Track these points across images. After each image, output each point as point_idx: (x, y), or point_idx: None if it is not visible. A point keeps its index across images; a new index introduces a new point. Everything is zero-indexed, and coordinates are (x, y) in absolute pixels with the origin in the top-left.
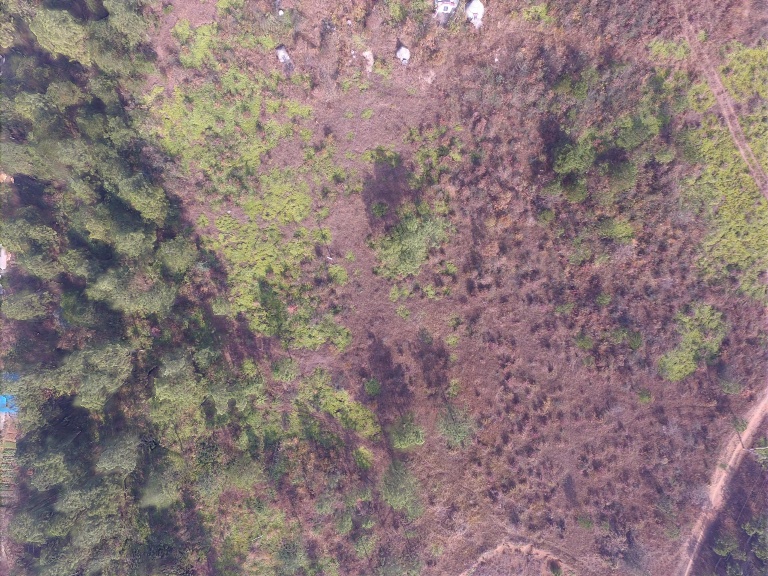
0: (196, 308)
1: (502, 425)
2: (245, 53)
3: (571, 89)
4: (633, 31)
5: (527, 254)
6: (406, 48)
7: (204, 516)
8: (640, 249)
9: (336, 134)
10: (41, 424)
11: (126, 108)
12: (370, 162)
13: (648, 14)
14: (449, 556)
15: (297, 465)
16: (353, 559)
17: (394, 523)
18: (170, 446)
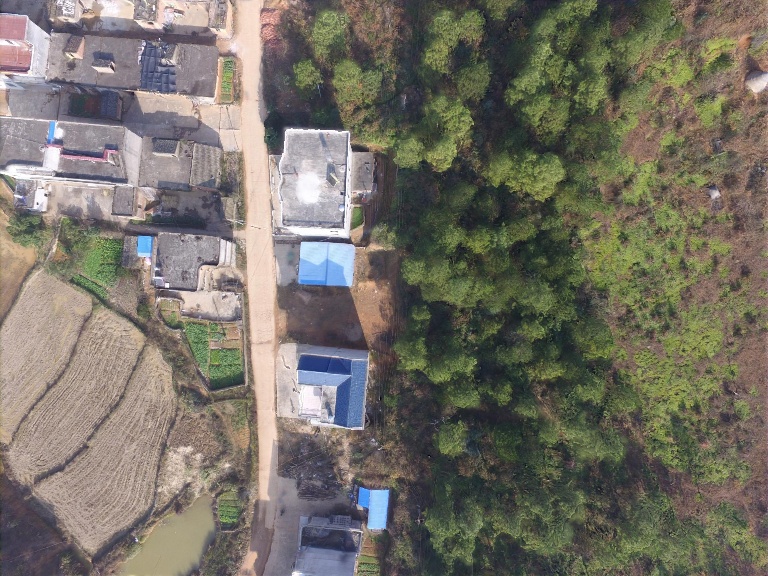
0: None
1: None
2: (679, 191)
3: None
4: None
5: None
6: None
7: None
8: None
9: (753, 273)
10: None
11: (573, 245)
12: None
13: None
14: None
15: None
16: None
17: None
18: None
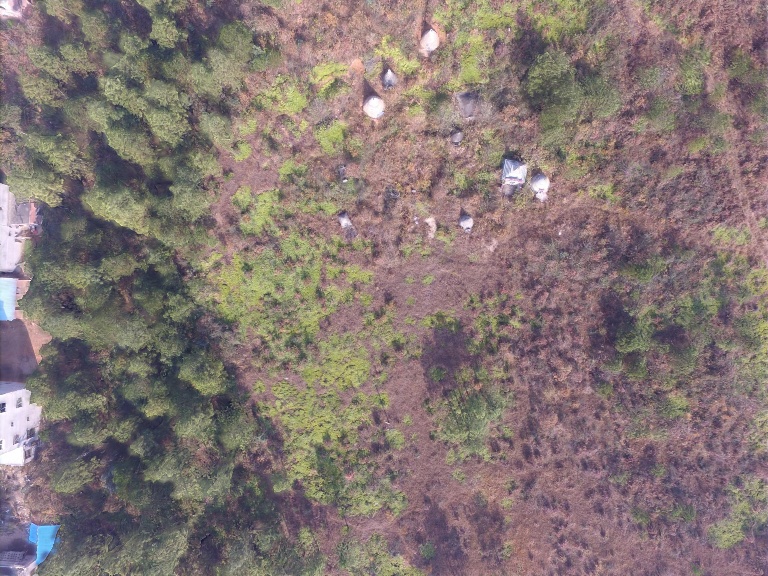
0: (252, 477)
1: None
2: (307, 219)
3: (636, 273)
4: (698, 218)
5: (583, 421)
6: (470, 217)
7: None
8: (694, 423)
9: (397, 300)
10: None
11: (184, 279)
12: (430, 327)
13: (714, 203)
14: None
15: None
16: None
17: None
18: None
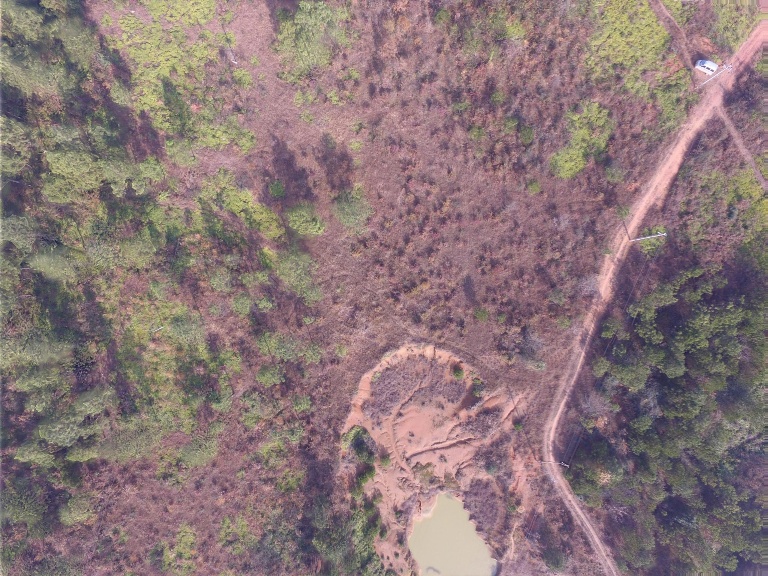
0: (99, 105)
1: (404, 228)
2: None
3: None
4: None
5: (426, 59)
6: None
7: (104, 309)
8: (531, 49)
9: None
10: None
11: None
12: None
13: None
14: (353, 357)
15: (199, 259)
16: (256, 355)
17: (297, 322)
18: (72, 244)
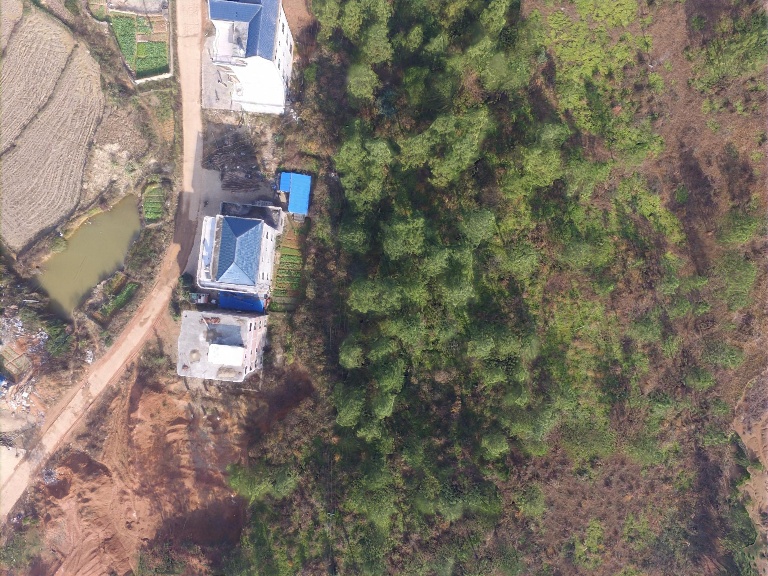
0: (527, 101)
1: None
2: None
3: None
4: None
5: None
6: None
7: (528, 305)
8: None
9: None
10: (366, 207)
11: None
12: None
13: None
14: (740, 363)
15: (618, 260)
16: (660, 357)
17: (695, 327)
18: (490, 238)
